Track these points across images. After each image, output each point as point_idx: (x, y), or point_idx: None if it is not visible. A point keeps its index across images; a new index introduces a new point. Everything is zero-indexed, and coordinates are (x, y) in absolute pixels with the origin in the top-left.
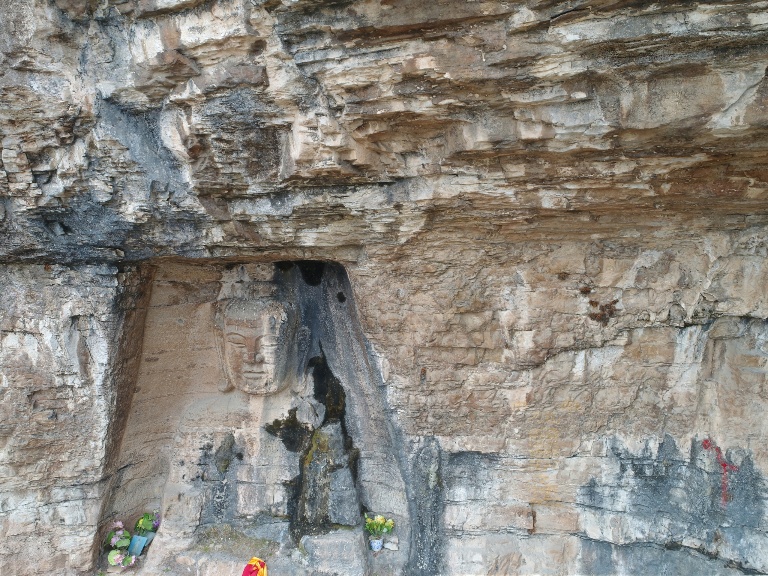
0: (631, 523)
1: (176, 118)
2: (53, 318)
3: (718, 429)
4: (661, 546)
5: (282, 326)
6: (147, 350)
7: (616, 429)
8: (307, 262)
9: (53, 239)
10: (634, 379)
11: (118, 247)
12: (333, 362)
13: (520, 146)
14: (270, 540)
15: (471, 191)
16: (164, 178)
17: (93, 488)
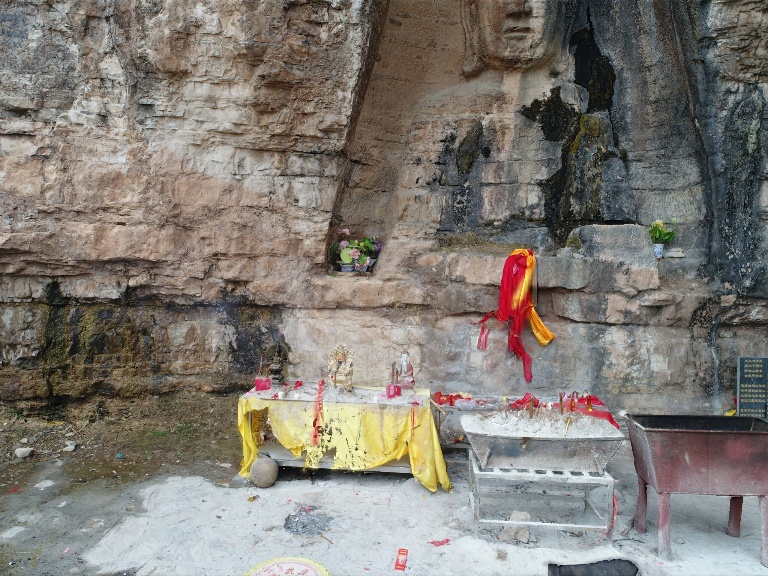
0: None
1: None
2: None
3: None
4: None
5: None
6: (392, 7)
7: None
8: None
9: None
10: None
11: None
12: (603, 34)
13: None
14: (525, 244)
15: None
16: None
17: (332, 162)
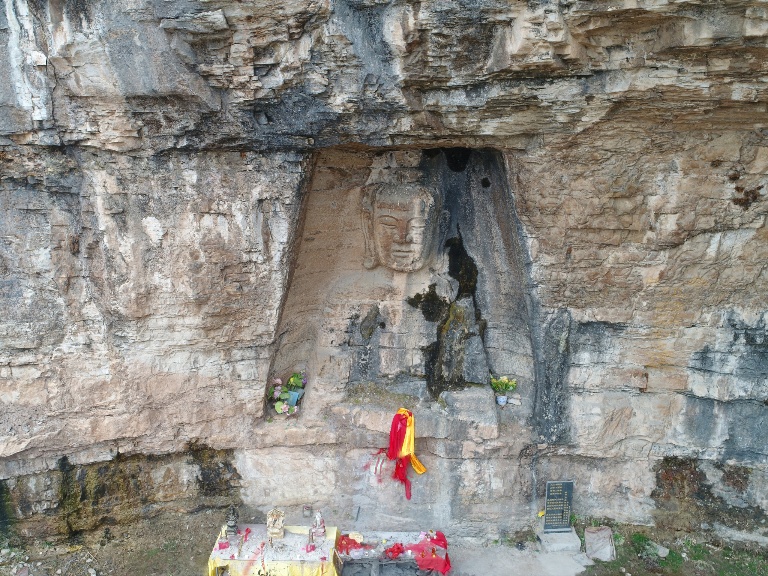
0: (736, 383)
1: (403, 14)
2: (244, 201)
3: None
4: (761, 402)
5: (430, 209)
6: (306, 231)
7: (735, 303)
8: (454, 149)
9: (257, 128)
10: (760, 259)
11: (310, 136)
12: (469, 243)
13: (740, 42)
14: (410, 395)
15: (668, 84)
16: (377, 71)
17: (264, 350)
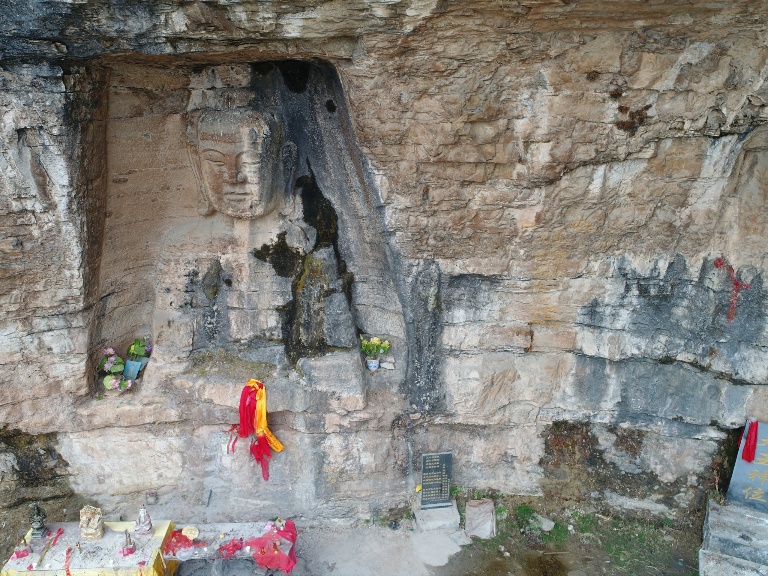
0: (629, 340)
1: None
2: None
3: (733, 247)
4: (655, 361)
5: (265, 141)
6: (113, 170)
7: (626, 249)
8: (289, 63)
9: None
10: (653, 196)
11: (57, 39)
12: (323, 182)
13: None
14: (266, 363)
15: None
16: None
17: (76, 317)
